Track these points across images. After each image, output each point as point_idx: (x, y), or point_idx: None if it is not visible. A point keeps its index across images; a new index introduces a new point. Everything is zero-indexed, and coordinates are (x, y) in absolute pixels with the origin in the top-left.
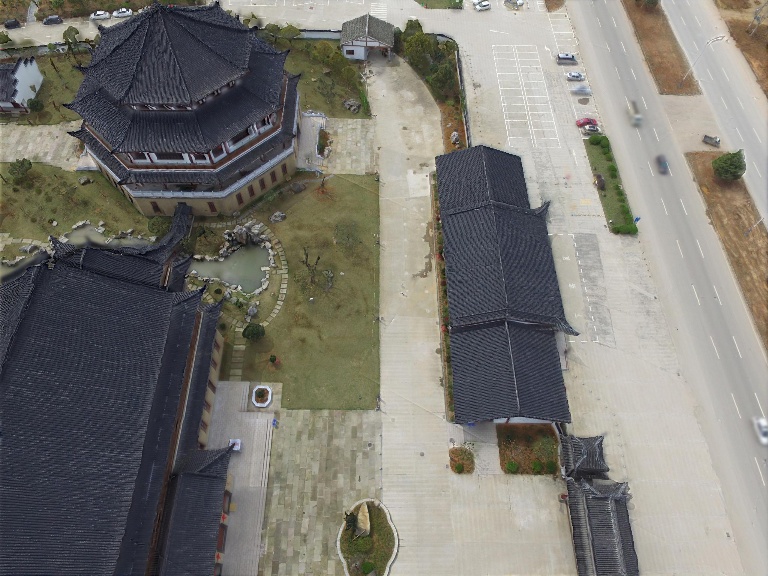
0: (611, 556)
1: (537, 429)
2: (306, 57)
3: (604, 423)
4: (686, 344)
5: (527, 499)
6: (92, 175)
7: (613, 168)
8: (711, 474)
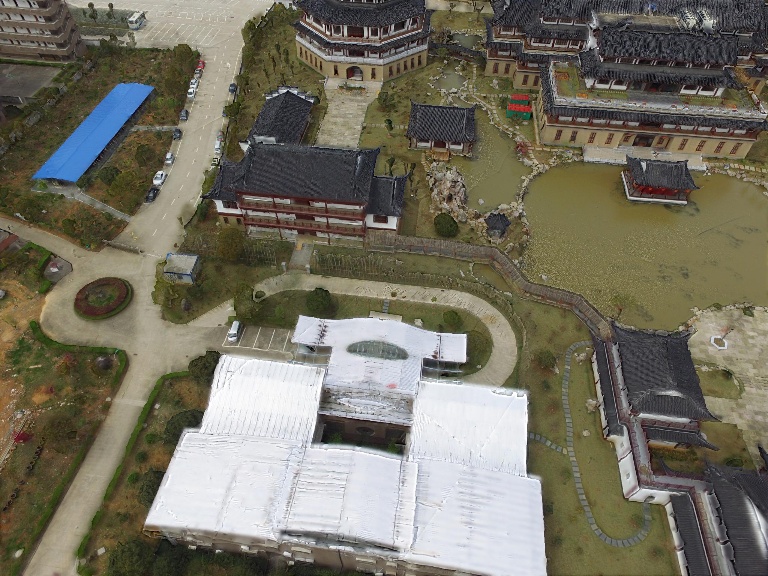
0: None
1: None
2: (289, 20)
3: None
4: None
5: None
6: (387, 85)
7: None
8: None
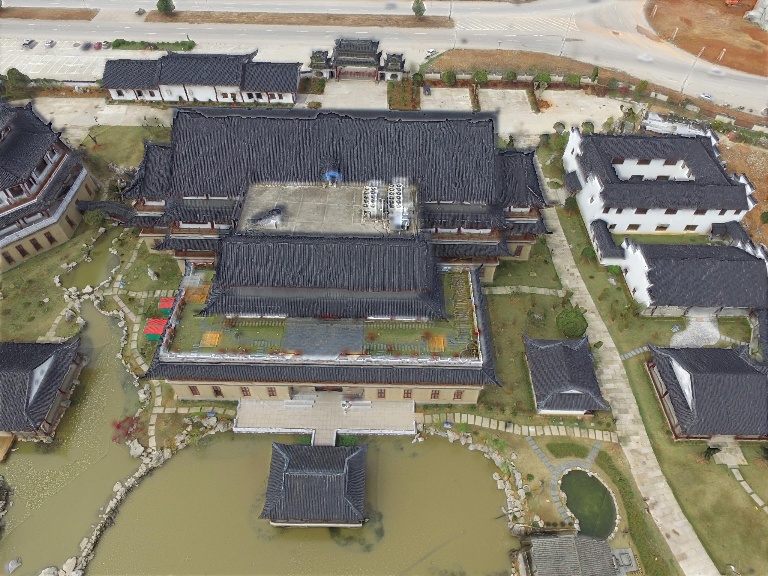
0: (363, 46)
1: (302, 83)
2: None
3: (303, 67)
4: (267, 42)
5: (336, 90)
6: None
7: (143, 41)
8: (331, 47)
